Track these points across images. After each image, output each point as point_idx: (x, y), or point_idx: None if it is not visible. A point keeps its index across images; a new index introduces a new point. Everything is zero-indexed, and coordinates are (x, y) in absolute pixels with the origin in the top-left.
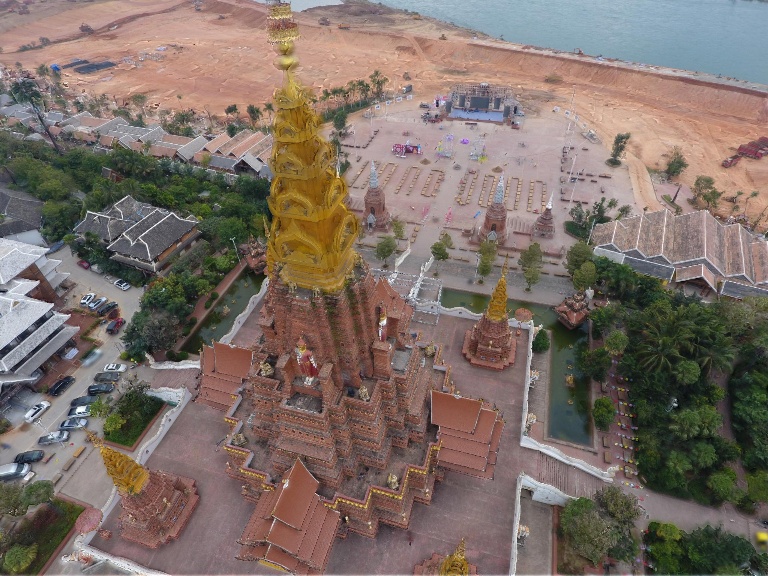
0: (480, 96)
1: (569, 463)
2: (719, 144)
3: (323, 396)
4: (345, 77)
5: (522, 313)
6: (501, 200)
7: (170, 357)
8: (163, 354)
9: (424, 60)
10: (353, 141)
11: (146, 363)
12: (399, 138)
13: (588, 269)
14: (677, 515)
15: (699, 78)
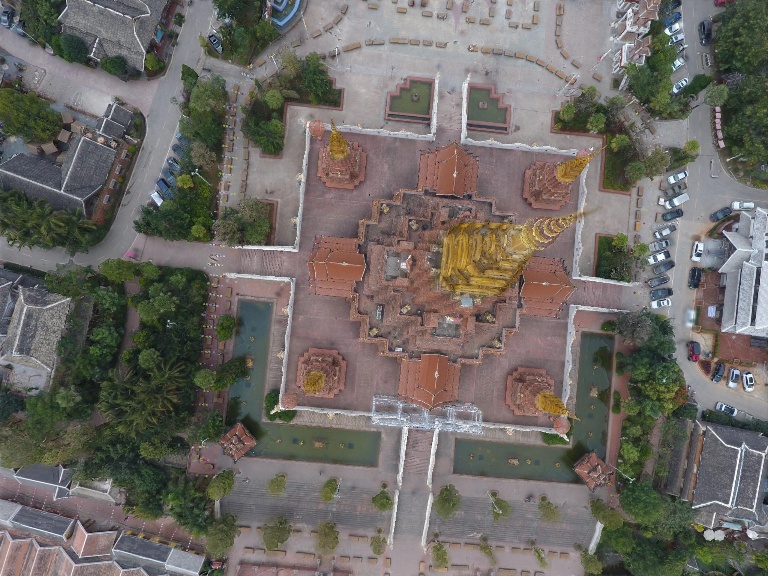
0: None
1: None
2: None
3: None
4: None
5: (290, 401)
6: None
7: None
8: None
9: None
10: None
11: None
12: None
13: (216, 487)
14: (188, 257)
15: None
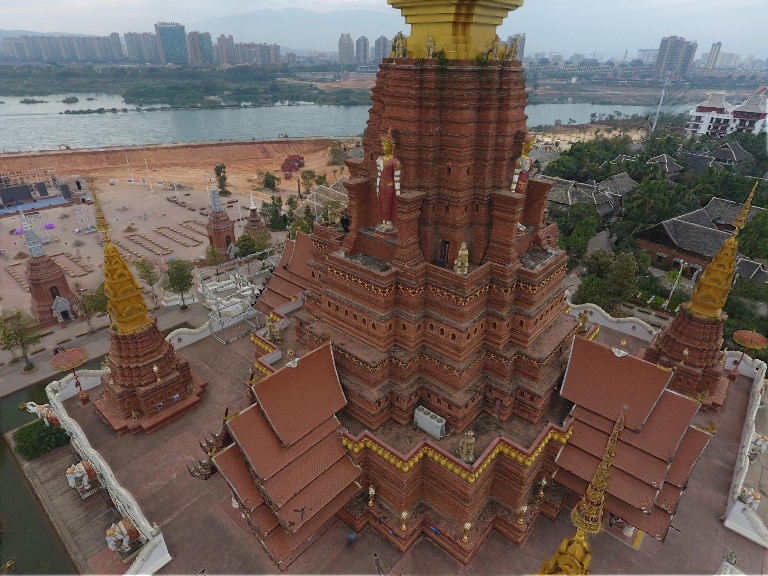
0: (12, 186)
1: None
2: None
3: (539, 235)
4: None
5: None
6: (221, 206)
7: None
8: None
9: None
10: None
11: None
12: None
13: None
14: None
15: (200, 143)
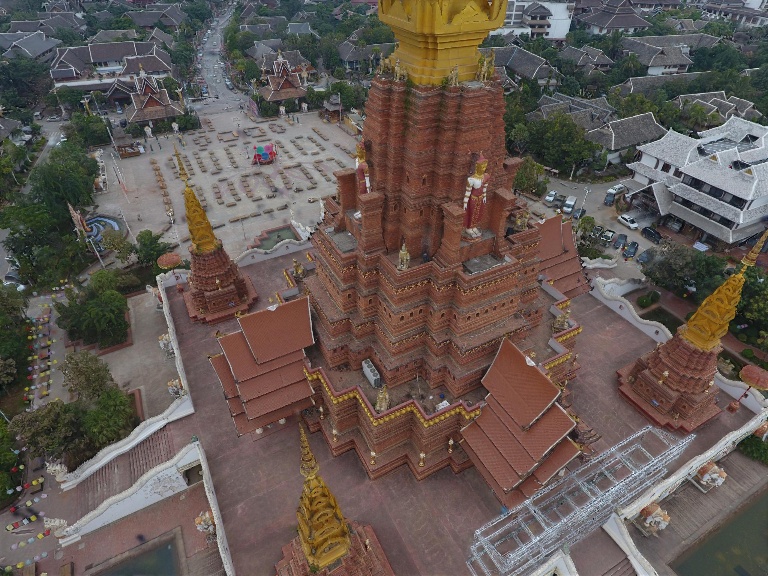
0: None
1: None
2: None
3: None
4: None
5: None
6: None
7: None
8: (661, 295)
9: None
10: None
11: None
12: None
13: None
14: None
15: None
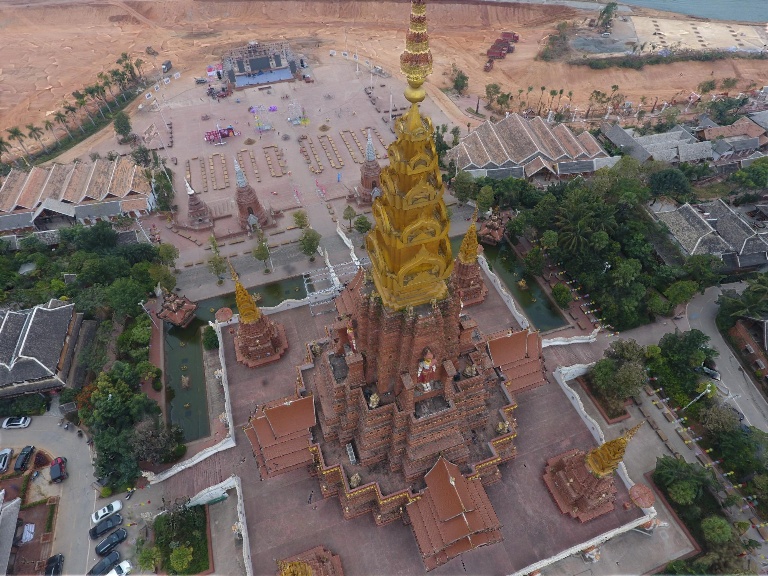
0: (258, 57)
1: (569, 343)
2: (471, 53)
3: (445, 392)
4: (73, 69)
5: None
6: (374, 157)
7: (166, 461)
8: None
9: (156, 28)
10: (151, 143)
11: (140, 484)
12: (201, 124)
13: (489, 191)
14: (639, 339)
15: None
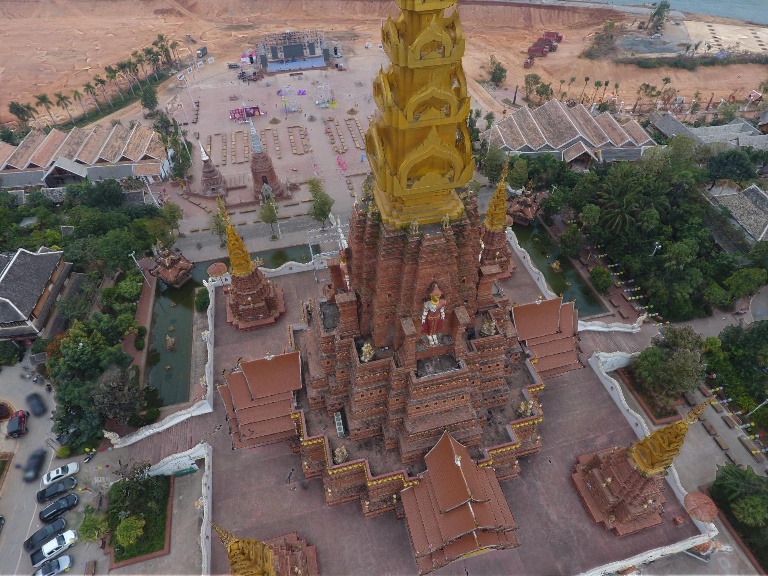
0: (292, 44)
1: (608, 330)
2: (512, 51)
3: (455, 349)
4: (112, 53)
5: None
6: None
7: (135, 424)
8: (120, 425)
9: (198, 20)
10: (176, 119)
11: (103, 447)
12: (228, 104)
13: (522, 165)
14: None
15: None
